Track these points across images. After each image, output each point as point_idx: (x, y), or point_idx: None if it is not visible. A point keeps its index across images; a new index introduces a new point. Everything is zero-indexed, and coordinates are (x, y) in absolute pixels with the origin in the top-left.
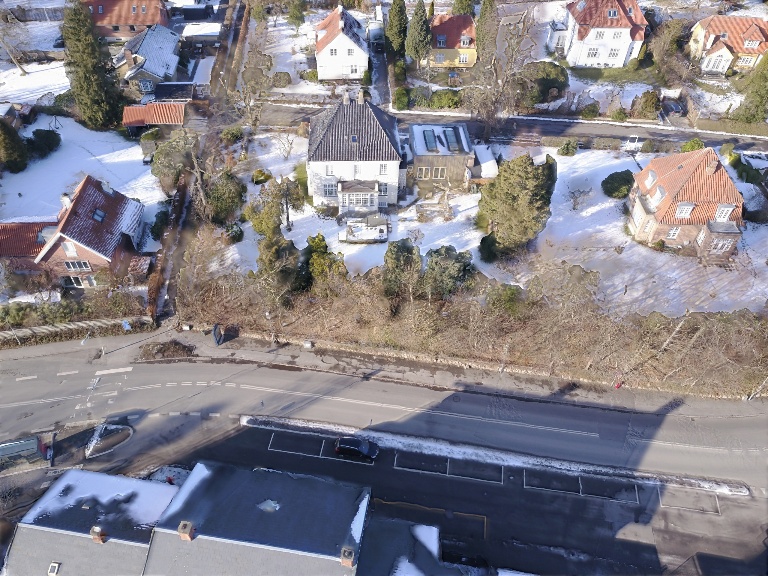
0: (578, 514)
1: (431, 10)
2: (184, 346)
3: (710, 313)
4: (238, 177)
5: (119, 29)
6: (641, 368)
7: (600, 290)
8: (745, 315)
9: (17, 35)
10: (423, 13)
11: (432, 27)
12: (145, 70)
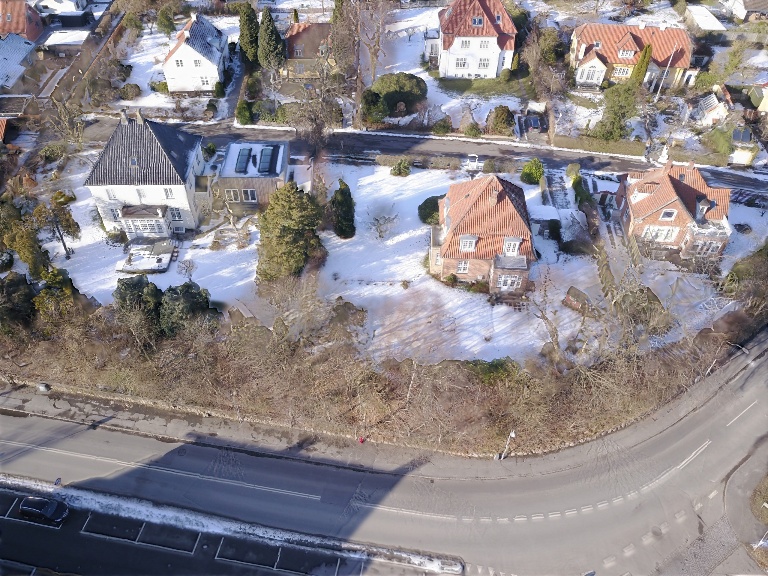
0: None
1: (295, 18)
2: None
3: (464, 362)
4: (41, 198)
5: None
6: (386, 421)
7: (365, 331)
8: (503, 364)
9: None
10: (269, 22)
11: (289, 36)
12: None
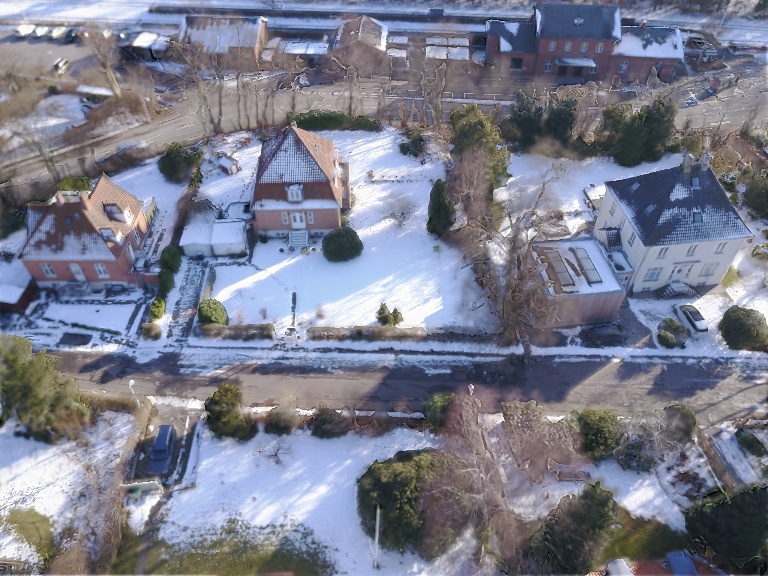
0: None
1: None
2: (690, 135)
3: (328, 114)
4: None
5: None
6: None
7: None
8: (302, 115)
9: None
10: (754, 490)
11: None
12: None
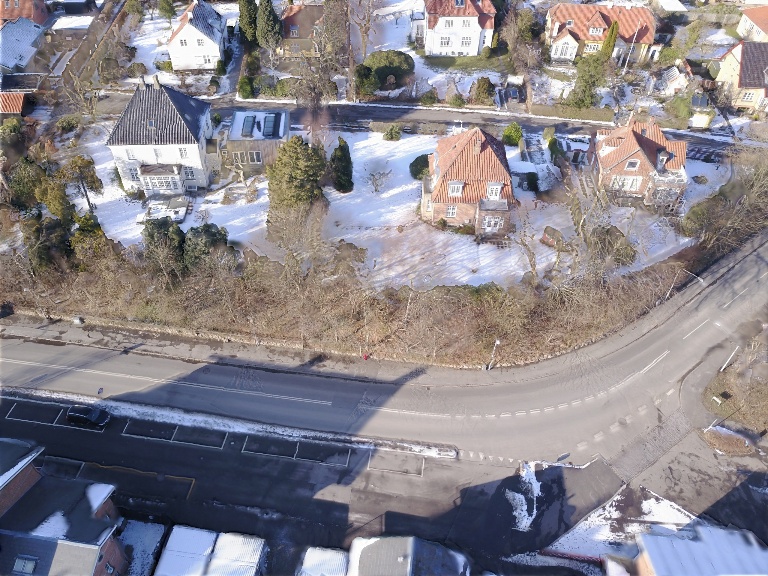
0: (285, 476)
1: (290, 1)
2: None
3: (454, 286)
4: (61, 163)
5: None
6: (387, 340)
7: (366, 266)
8: (489, 288)
9: None
10: (267, 3)
11: (285, 17)
12: None
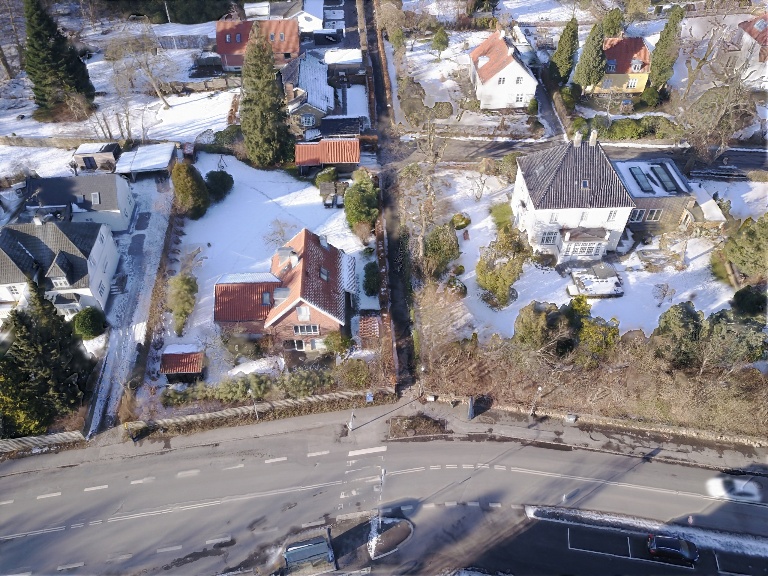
0: None
1: None
2: (435, 420)
3: None
4: (433, 221)
5: None
6: None
7: None
8: None
9: (165, 68)
10: (601, 38)
11: None
12: (310, 104)
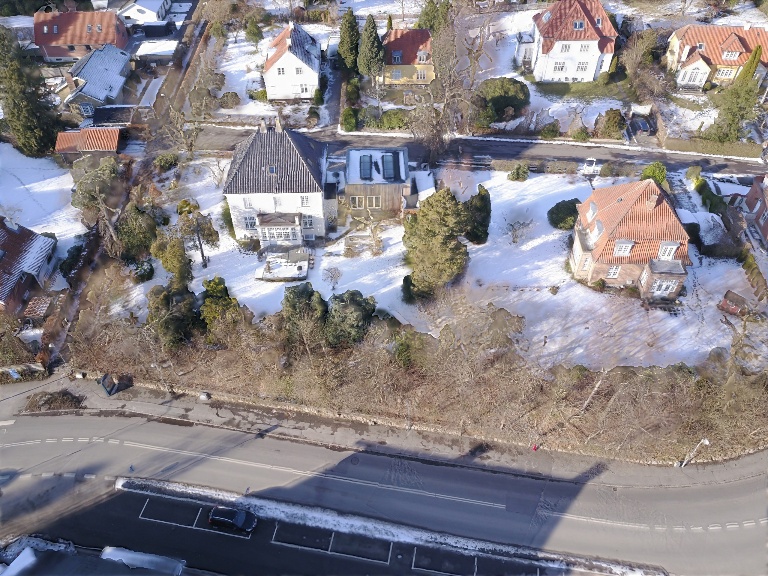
0: None
1: (389, 24)
2: (73, 396)
3: (639, 368)
4: (164, 207)
5: (75, 49)
6: (561, 429)
7: (525, 338)
8: (680, 370)
9: None
10: (373, 29)
11: (387, 43)
12: (84, 93)
